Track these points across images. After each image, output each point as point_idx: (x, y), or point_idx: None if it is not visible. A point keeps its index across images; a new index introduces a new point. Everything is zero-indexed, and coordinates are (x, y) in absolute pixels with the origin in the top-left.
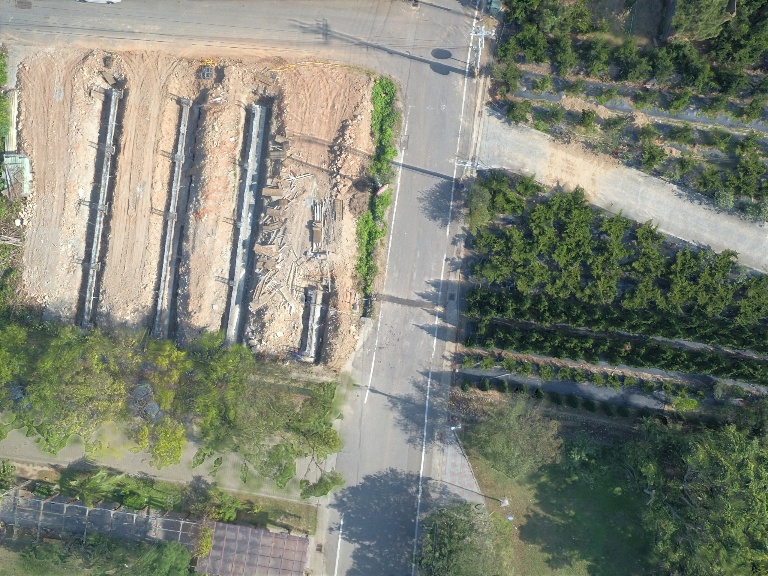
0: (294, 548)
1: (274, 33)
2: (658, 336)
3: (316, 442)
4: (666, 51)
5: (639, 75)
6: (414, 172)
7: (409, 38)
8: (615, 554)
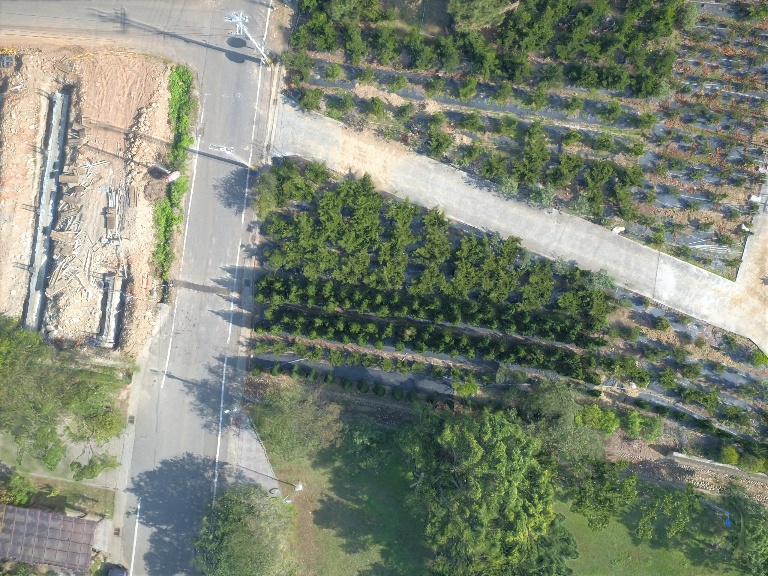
0: (82, 531)
1: (73, 22)
2: (447, 322)
3: (95, 425)
4: (453, 39)
5: (428, 63)
6: (210, 159)
7: (205, 27)
8: (408, 538)
